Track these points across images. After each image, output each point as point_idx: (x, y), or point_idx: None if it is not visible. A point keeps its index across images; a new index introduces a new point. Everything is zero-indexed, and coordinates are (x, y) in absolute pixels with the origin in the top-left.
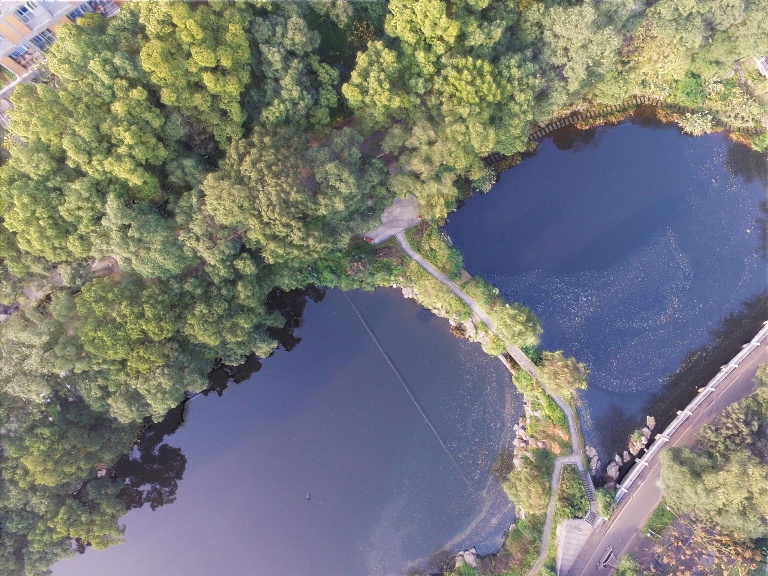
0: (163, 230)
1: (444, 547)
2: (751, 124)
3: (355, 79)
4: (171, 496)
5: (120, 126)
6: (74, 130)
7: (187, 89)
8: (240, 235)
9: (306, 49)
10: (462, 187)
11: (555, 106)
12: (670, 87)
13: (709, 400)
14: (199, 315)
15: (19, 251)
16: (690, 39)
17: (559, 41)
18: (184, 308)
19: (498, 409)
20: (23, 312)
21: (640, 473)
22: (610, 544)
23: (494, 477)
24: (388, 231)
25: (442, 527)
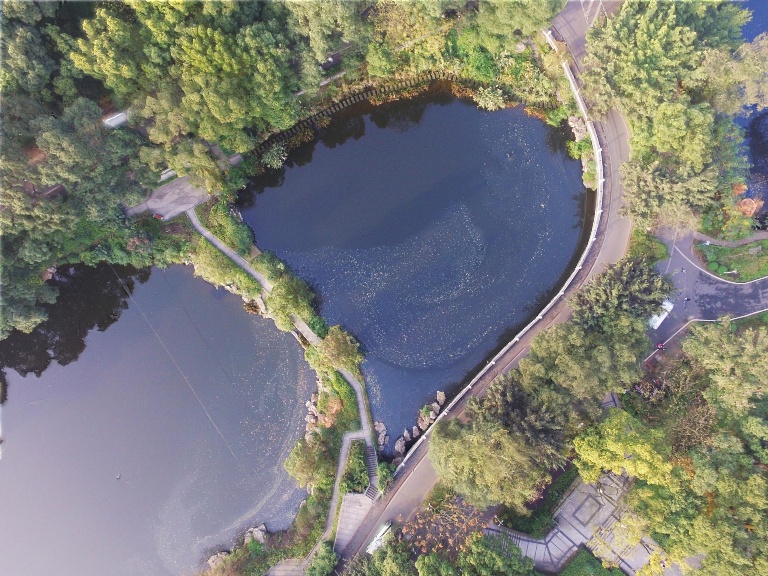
0: None
1: (233, 524)
2: (545, 98)
3: (81, 48)
4: None
5: None
6: None
7: None
8: None
9: (35, 18)
10: (254, 163)
11: (309, 77)
12: (463, 61)
13: (493, 374)
14: None
15: None
16: (430, 7)
17: (297, 10)
18: None
19: (290, 385)
20: None
21: (420, 447)
22: (390, 518)
23: (285, 454)
24: (179, 208)
25: (231, 504)
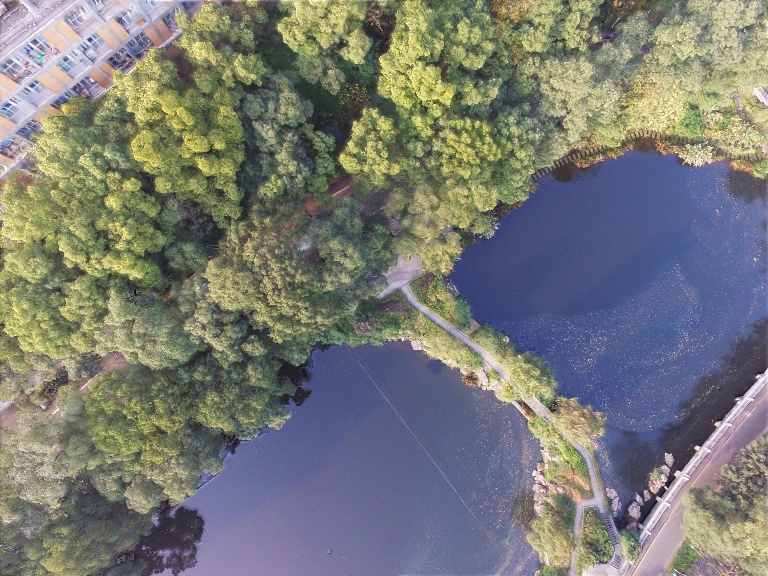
0: (168, 322)
1: None
2: (752, 151)
3: (352, 150)
4: (191, 561)
5: (116, 221)
6: None
7: (182, 175)
8: (246, 316)
9: (300, 121)
10: (465, 234)
11: (556, 156)
12: (668, 119)
13: (727, 435)
14: (210, 404)
15: (21, 351)
16: (690, 83)
17: (557, 94)
18: (194, 396)
19: (515, 456)
20: (28, 397)
21: (662, 514)
22: None
23: (516, 525)
24: (393, 284)
25: None
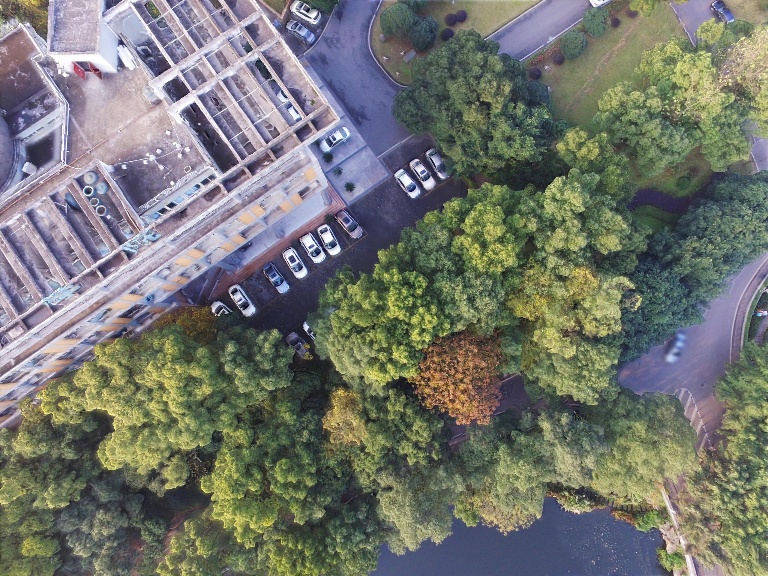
0: None
1: None
2: (634, 504)
3: None
4: None
5: None
6: None
7: None
8: None
9: None
10: None
11: None
12: None
13: None
14: None
15: None
16: (531, 510)
17: None
18: None
19: None
20: None
21: None
22: None
23: None
24: None
25: None
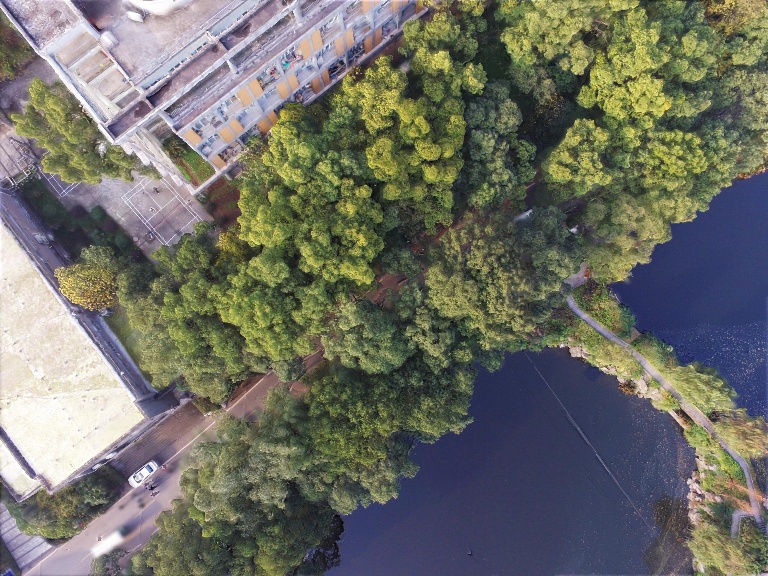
0: (391, 327)
1: None
2: None
3: (566, 160)
4: (335, 559)
5: (352, 228)
6: (305, 233)
7: (409, 183)
8: (455, 323)
9: (512, 130)
10: None
11: (748, 169)
12: None
13: None
14: (426, 408)
15: (241, 352)
16: None
17: (763, 107)
18: (406, 401)
19: (670, 464)
20: None
21: None
22: None
23: (670, 532)
24: None
25: None
